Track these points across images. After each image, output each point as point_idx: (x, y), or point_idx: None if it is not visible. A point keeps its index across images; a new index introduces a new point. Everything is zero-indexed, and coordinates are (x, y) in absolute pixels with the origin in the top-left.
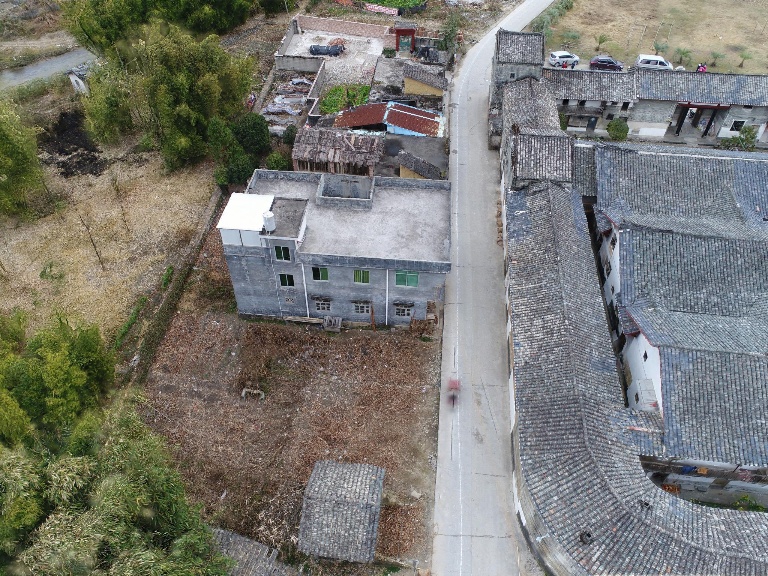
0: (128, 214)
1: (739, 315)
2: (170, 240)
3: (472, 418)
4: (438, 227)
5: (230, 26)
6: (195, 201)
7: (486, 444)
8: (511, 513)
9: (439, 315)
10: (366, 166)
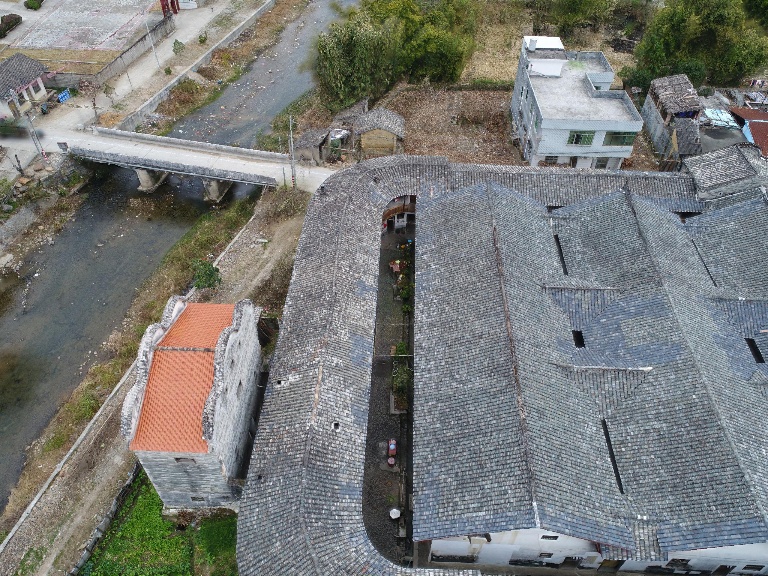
0: None
1: (569, 273)
2: None
3: None
4: None
5: None
6: None
7: None
8: None
9: None
10: None
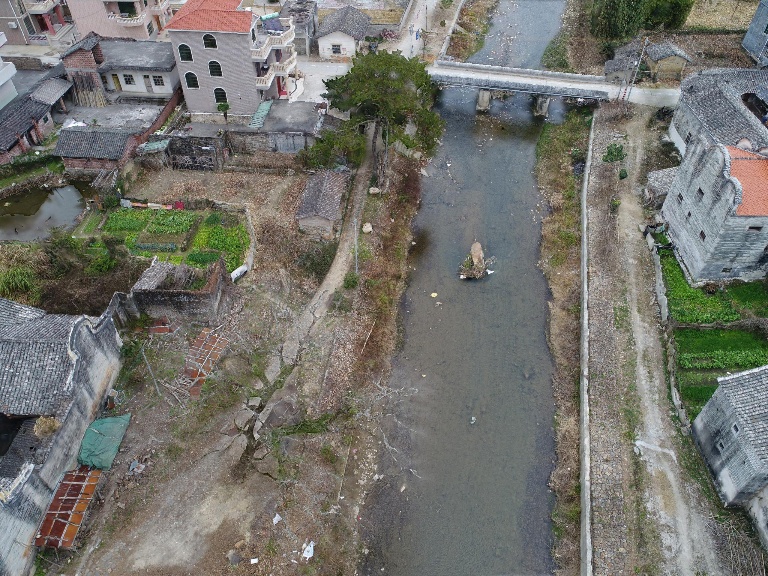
0: None
1: None
2: None
3: None
4: None
5: None
6: None
7: None
8: None
9: None
10: None
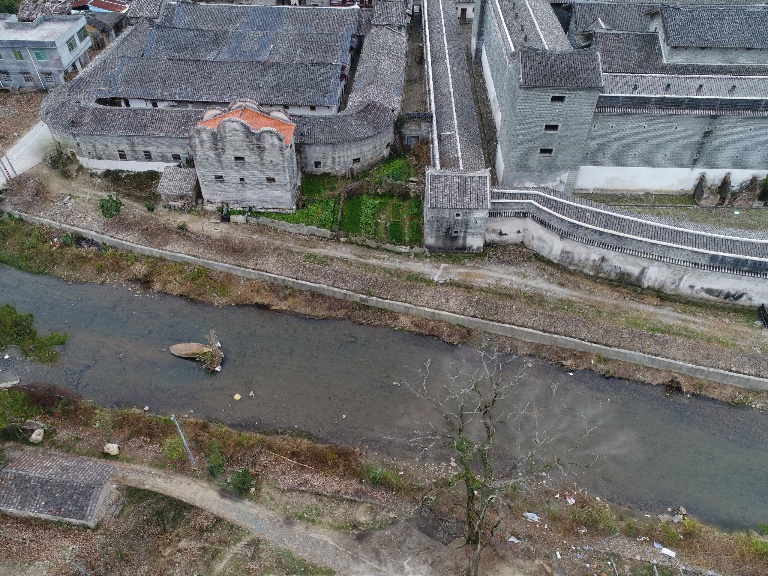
0: None
1: None
2: None
3: None
4: None
5: None
6: None
7: None
8: None
9: None
10: None
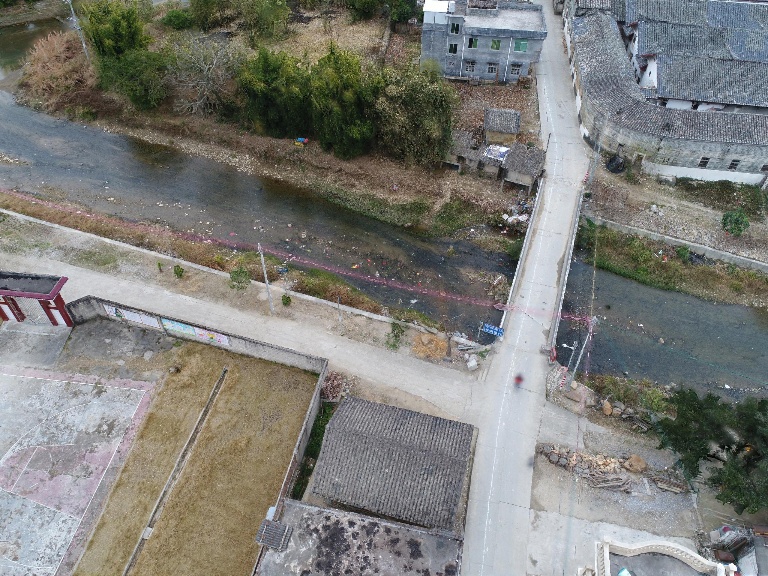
0: (334, 40)
1: None
2: (364, 52)
3: (557, 111)
4: (537, 24)
5: None
6: (373, 36)
7: (565, 119)
8: (580, 138)
9: (533, 79)
10: (485, 8)
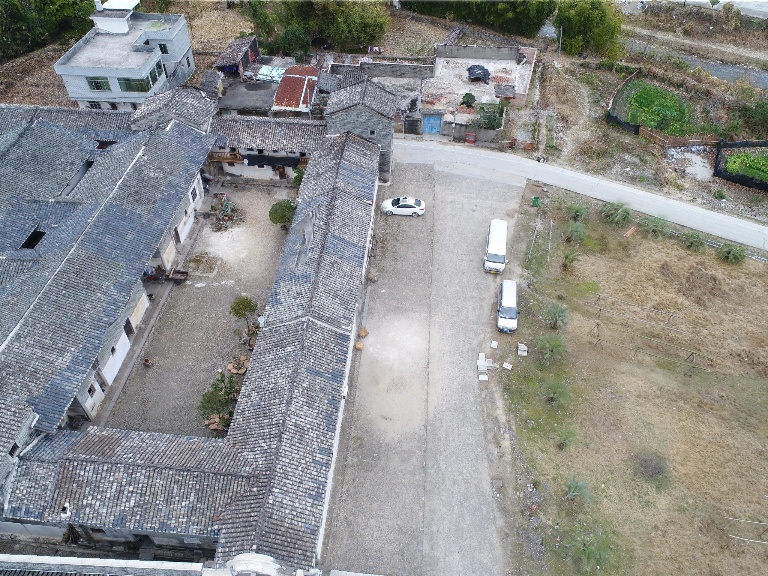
0: None
1: None
2: None
3: None
4: None
5: (504, 28)
6: None
7: None
8: None
9: None
10: None
